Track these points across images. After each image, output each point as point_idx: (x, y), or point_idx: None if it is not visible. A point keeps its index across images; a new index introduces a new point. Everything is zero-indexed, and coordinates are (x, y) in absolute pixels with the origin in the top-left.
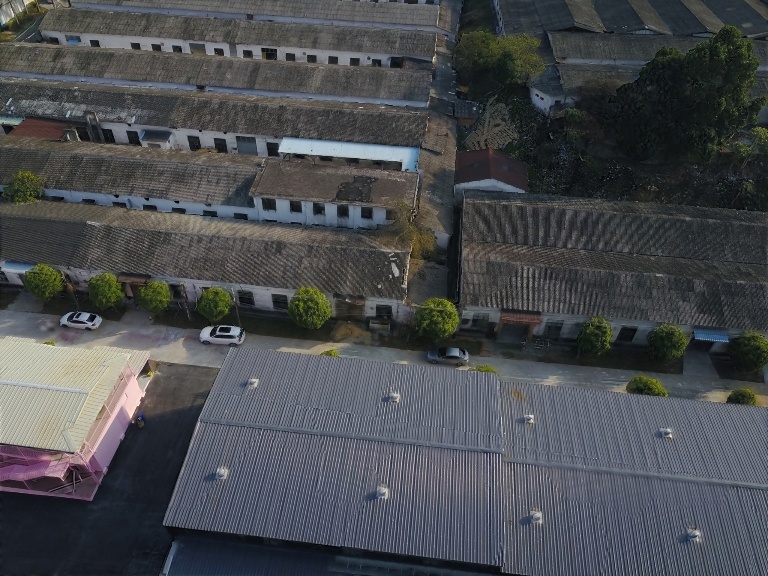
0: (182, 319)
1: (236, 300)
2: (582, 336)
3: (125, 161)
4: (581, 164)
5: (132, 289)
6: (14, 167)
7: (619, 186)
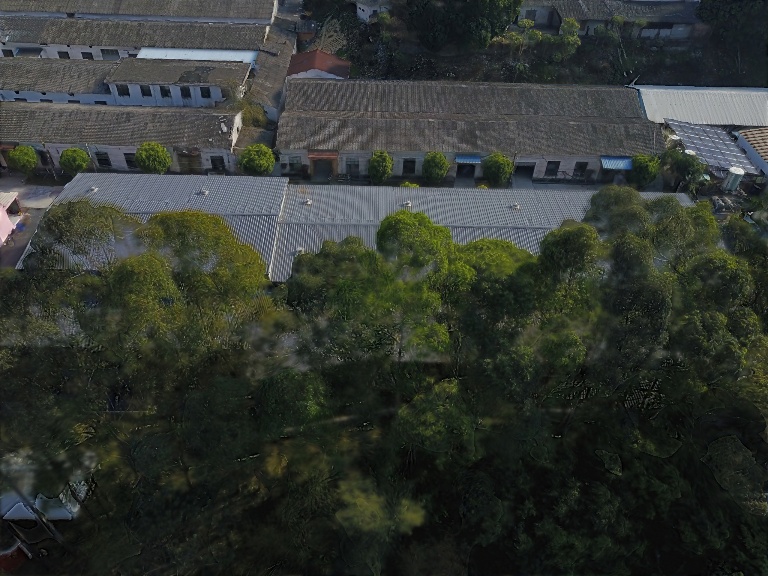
0: (50, 180)
1: (94, 161)
2: (369, 165)
3: None
4: (394, 59)
5: (5, 159)
6: None
7: (424, 74)
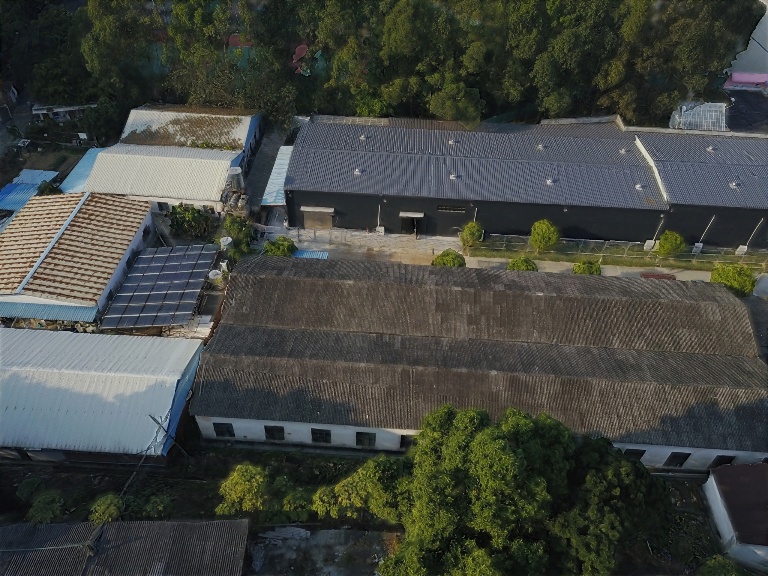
0: None
1: None
2: None
3: None
4: None
5: None
6: None
7: None
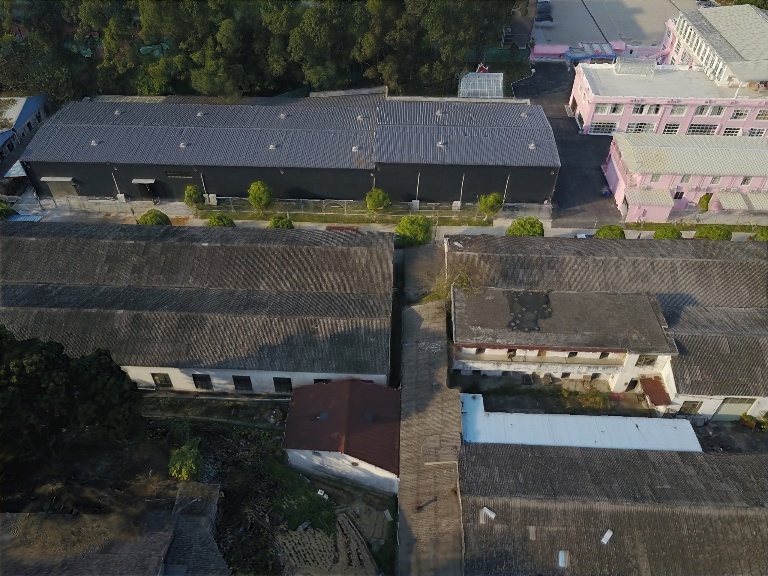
0: None
1: None
2: None
3: None
4: None
5: None
6: None
7: None
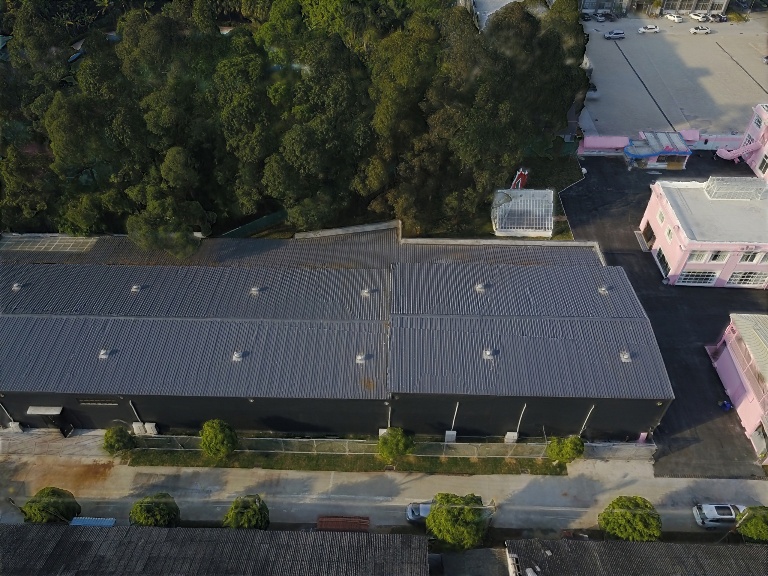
0: None
1: None
2: None
3: None
4: None
5: None
6: None
7: None
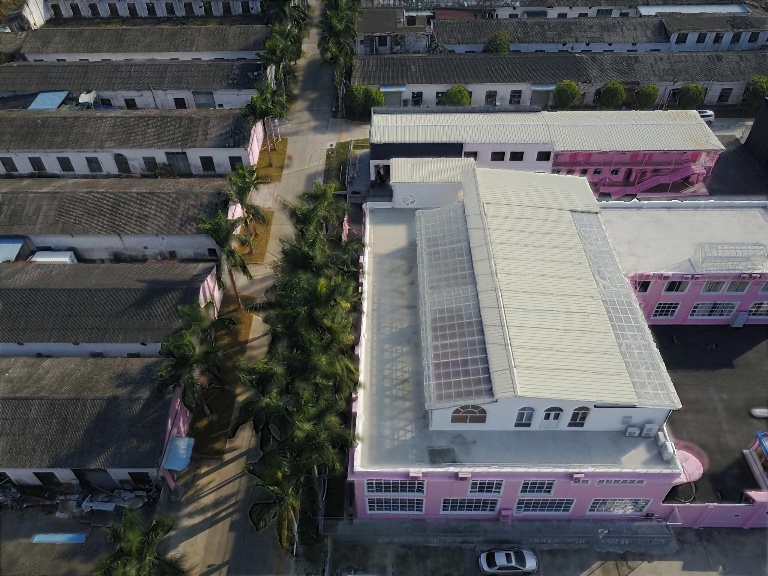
0: None
1: None
2: None
3: (559, 21)
4: None
5: None
6: (479, 32)
7: None
